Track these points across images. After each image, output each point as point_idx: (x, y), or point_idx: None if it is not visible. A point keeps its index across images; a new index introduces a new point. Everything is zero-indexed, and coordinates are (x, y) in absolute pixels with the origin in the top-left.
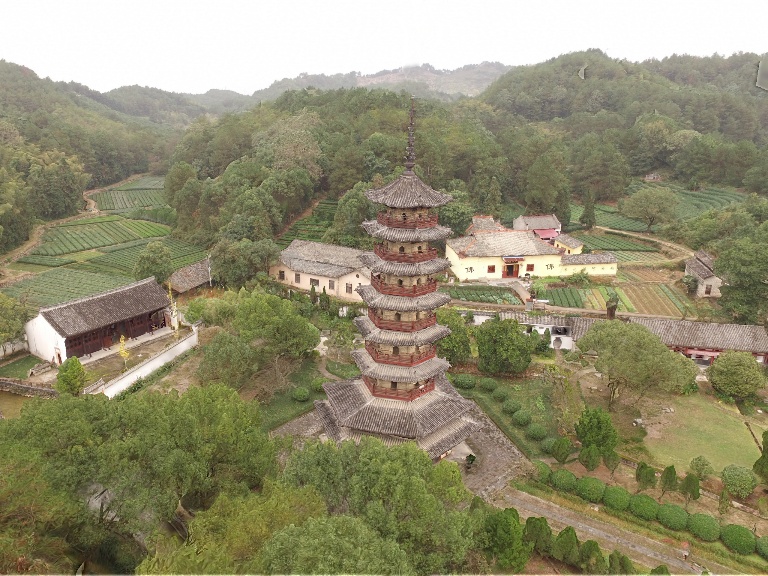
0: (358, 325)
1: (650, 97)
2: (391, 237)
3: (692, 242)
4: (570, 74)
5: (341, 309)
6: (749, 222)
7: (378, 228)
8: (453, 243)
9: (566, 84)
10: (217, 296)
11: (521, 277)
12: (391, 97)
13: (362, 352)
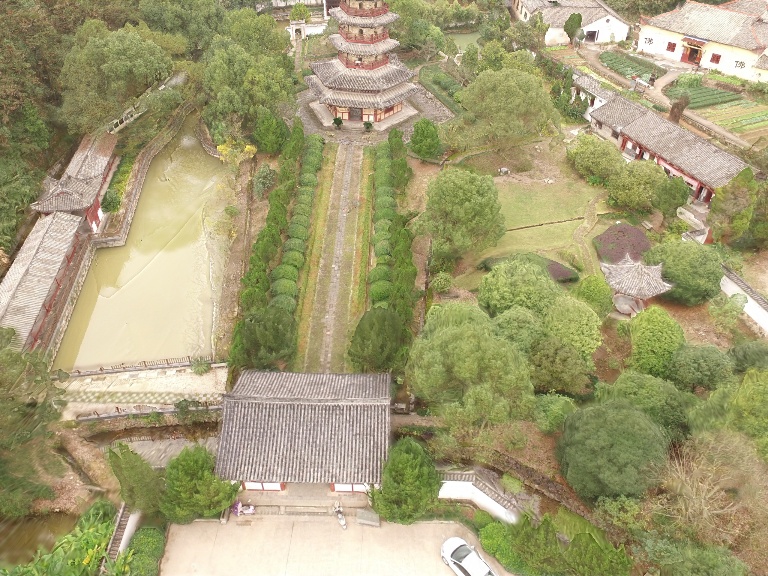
0: None
1: None
2: None
3: None
4: None
5: None
6: None
7: None
8: (670, 11)
9: None
10: None
11: (701, 67)
12: None
13: None
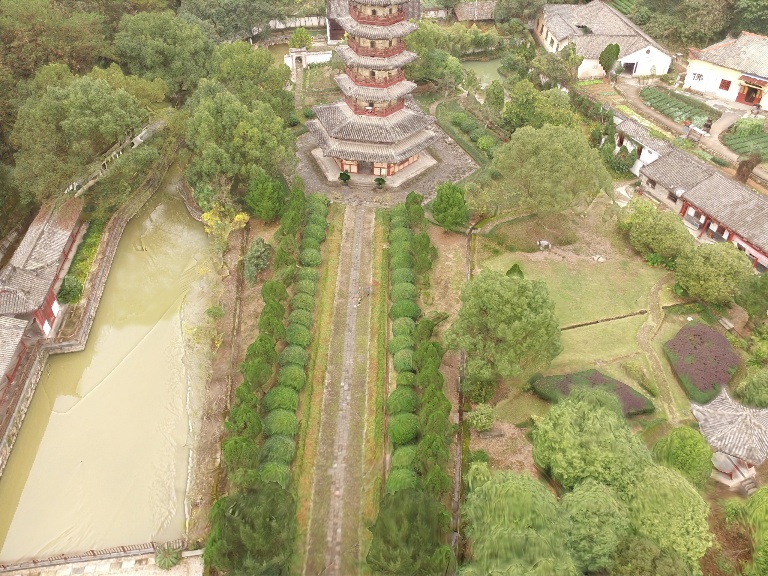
0: None
1: None
2: None
3: None
4: None
5: (530, 70)
6: None
7: None
8: (721, 42)
9: None
10: None
11: (760, 108)
12: None
13: None
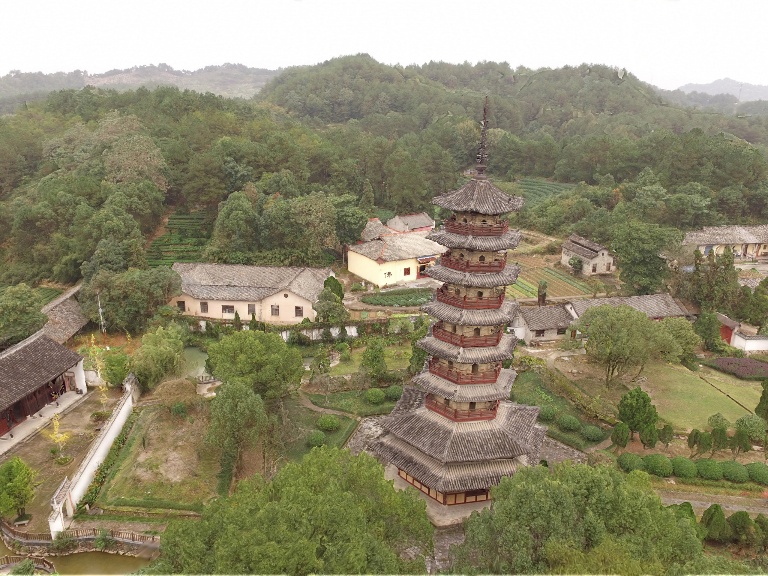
0: (426, 348)
1: (433, 99)
2: (482, 247)
3: (545, 228)
4: (352, 77)
5: (280, 335)
6: (591, 207)
7: (467, 238)
8: (360, 249)
9: (351, 87)
10: (104, 343)
11: None
12: (210, 98)
13: (426, 377)
